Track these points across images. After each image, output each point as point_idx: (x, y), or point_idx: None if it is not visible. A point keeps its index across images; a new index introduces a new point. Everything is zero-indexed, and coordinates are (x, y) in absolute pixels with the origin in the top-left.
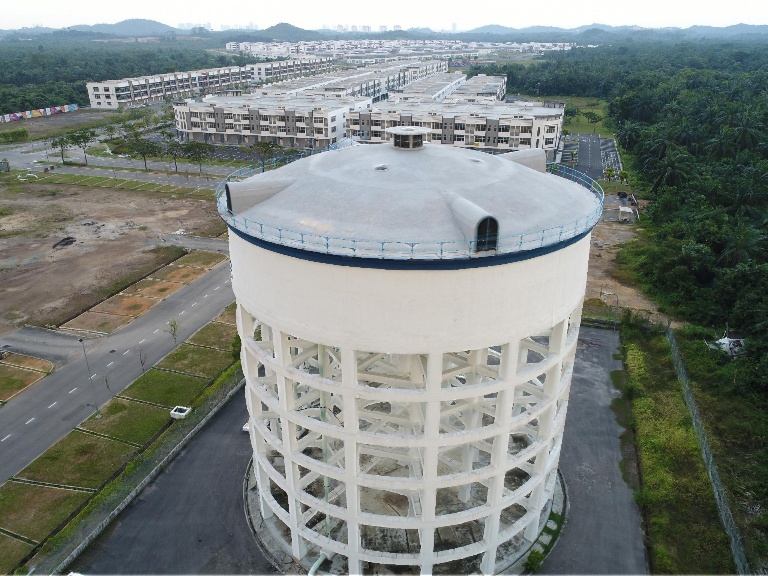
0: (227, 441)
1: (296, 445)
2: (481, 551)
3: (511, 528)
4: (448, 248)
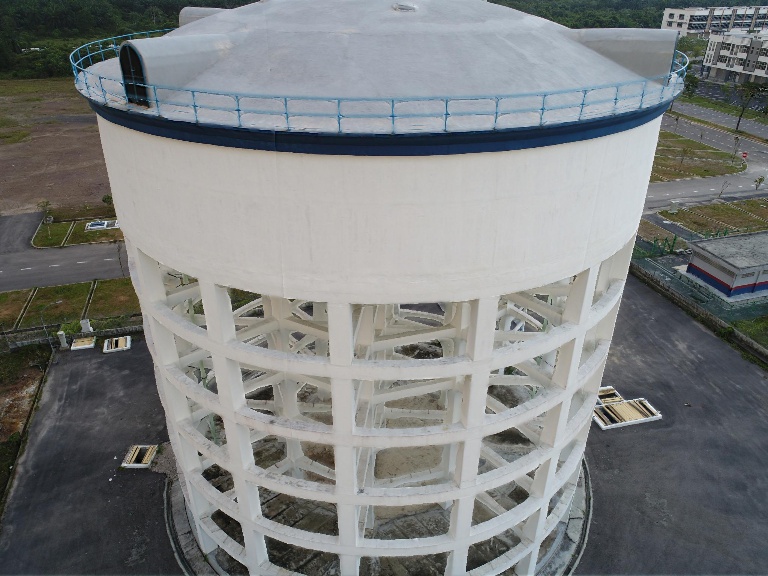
0: None
1: (179, 313)
2: (239, 560)
3: (287, 573)
4: (120, 89)
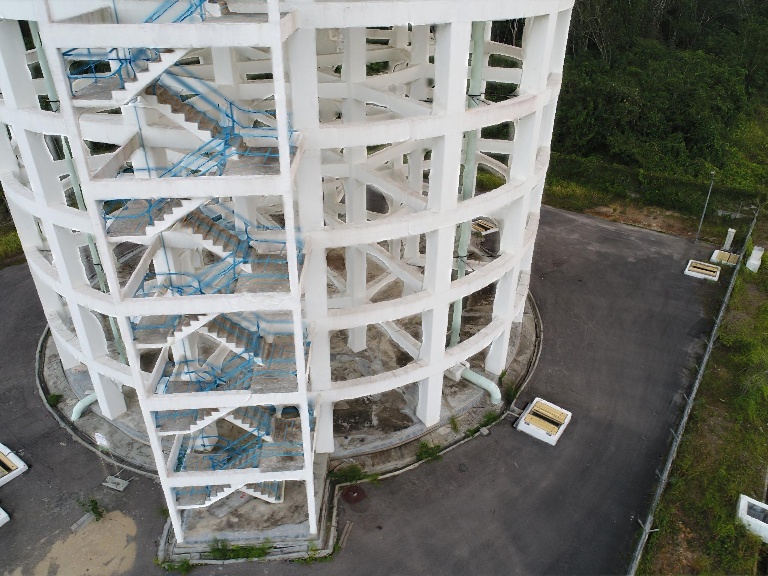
0: (597, 402)
1: None
2: None
3: None
4: None
